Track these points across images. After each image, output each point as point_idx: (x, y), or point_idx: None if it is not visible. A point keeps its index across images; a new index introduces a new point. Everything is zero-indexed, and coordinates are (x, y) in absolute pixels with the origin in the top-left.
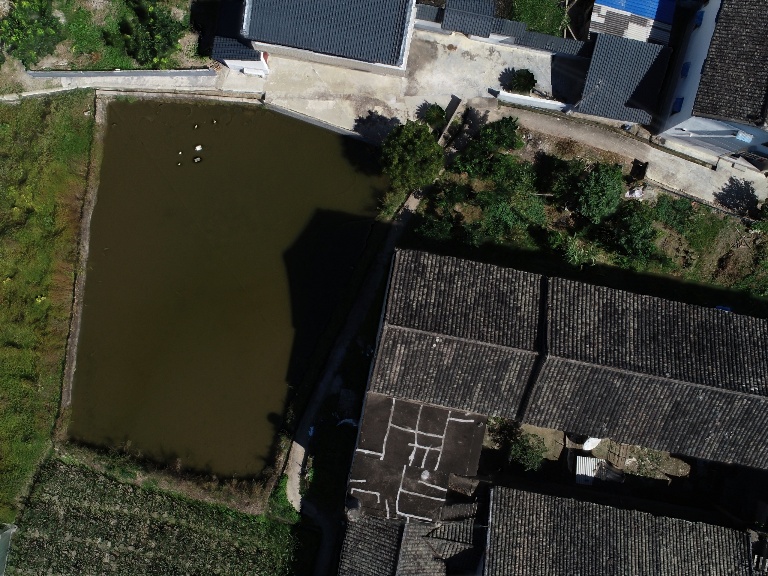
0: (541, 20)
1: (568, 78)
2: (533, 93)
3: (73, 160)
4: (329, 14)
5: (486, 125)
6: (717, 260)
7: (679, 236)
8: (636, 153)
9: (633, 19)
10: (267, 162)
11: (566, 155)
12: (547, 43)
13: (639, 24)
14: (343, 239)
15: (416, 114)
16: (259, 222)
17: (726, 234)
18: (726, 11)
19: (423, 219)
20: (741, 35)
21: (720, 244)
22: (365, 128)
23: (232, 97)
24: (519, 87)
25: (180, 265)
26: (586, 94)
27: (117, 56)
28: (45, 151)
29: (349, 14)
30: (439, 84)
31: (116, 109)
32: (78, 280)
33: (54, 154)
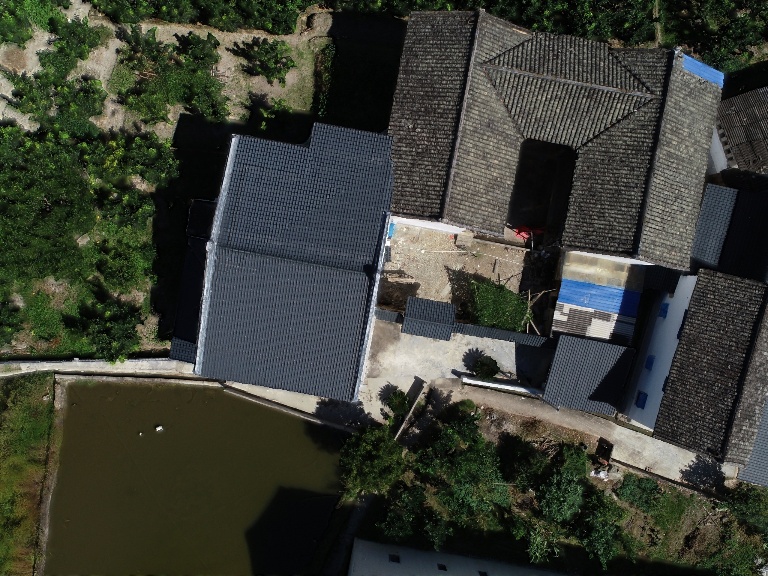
0: (503, 315)
1: (533, 358)
2: (497, 374)
3: (32, 447)
4: (282, 355)
5: (450, 405)
6: (683, 538)
7: (645, 514)
8: (602, 431)
9: (596, 315)
10: (230, 429)
11: (530, 435)
12: (509, 337)
13: (603, 319)
14: (306, 510)
15: (379, 396)
16: (221, 498)
17: (692, 512)
18: (687, 333)
19: (386, 500)
20: (702, 361)
21: (686, 522)
22: (327, 410)
23: (192, 380)
24: (482, 374)
25: (141, 544)
26: (549, 388)
27: (76, 340)
28: (2, 444)
29: (303, 355)
30: (402, 365)
31: (76, 389)
32: (37, 565)
33: (11, 447)
